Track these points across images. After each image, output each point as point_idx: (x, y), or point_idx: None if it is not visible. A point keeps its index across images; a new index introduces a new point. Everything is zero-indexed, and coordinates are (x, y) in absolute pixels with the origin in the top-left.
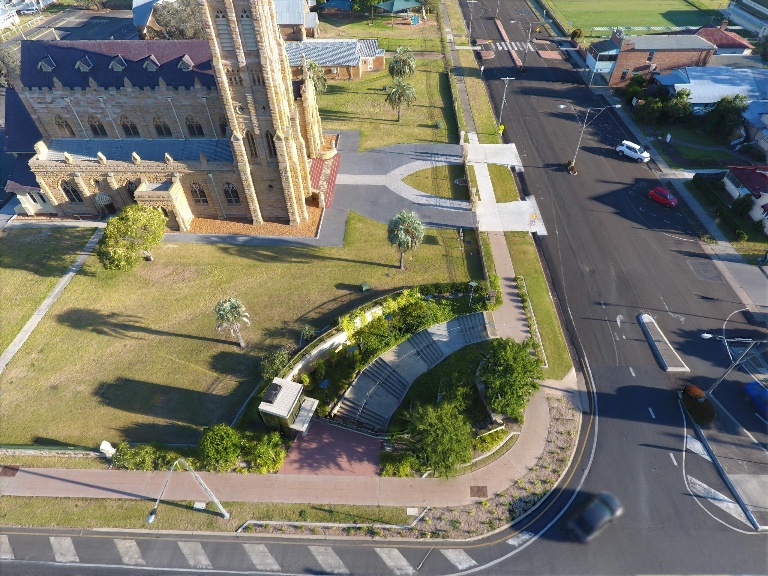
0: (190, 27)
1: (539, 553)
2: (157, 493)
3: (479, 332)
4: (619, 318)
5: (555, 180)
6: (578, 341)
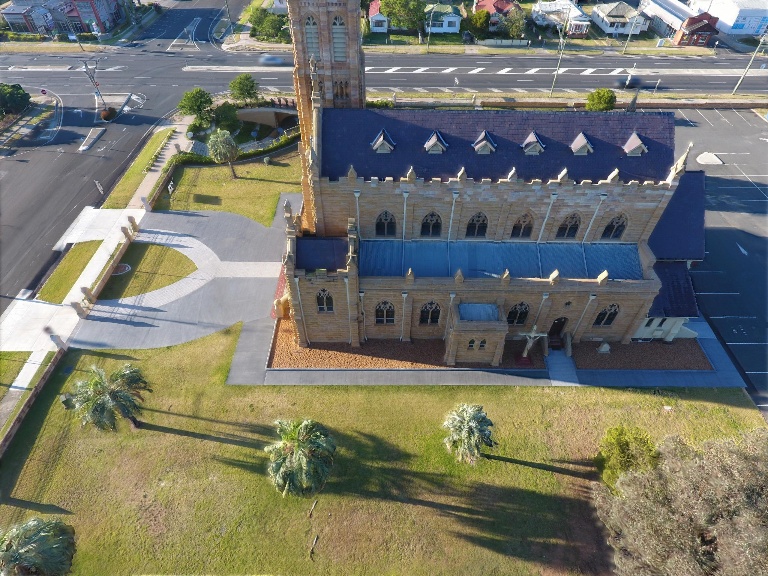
0: (668, 448)
1: (220, 90)
2: (369, 98)
3: (199, 147)
4: (101, 150)
5: (1, 270)
6: (140, 142)
